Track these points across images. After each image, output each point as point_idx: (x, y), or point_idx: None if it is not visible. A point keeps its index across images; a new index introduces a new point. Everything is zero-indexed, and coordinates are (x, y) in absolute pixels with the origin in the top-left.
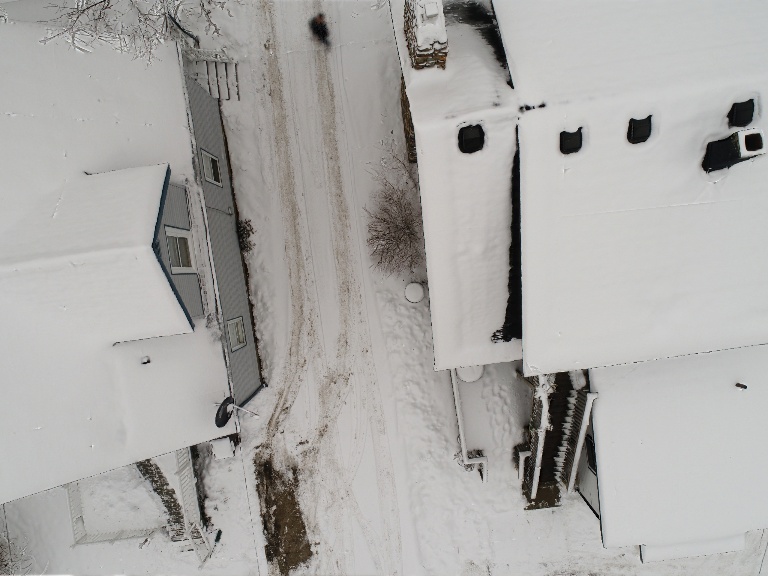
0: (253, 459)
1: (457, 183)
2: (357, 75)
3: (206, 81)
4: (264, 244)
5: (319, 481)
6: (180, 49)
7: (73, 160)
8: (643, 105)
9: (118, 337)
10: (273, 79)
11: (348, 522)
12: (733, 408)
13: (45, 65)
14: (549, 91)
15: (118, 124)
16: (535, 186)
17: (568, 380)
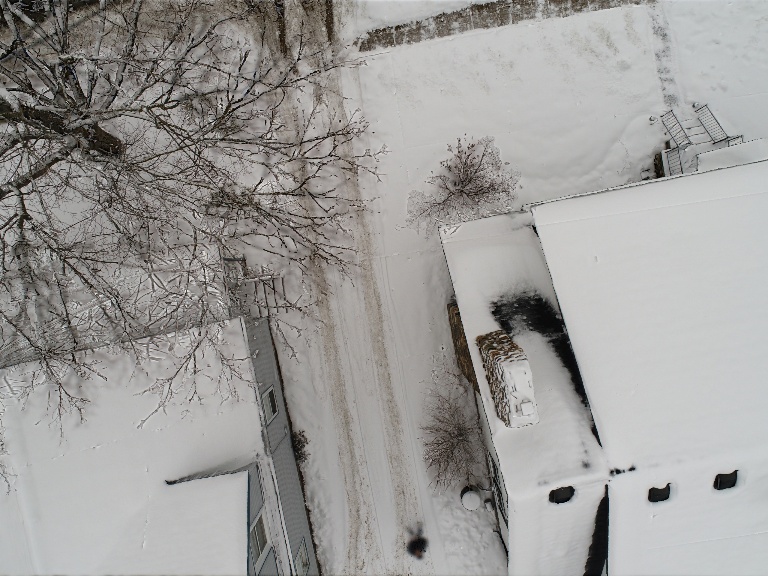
0: None
1: (545, 521)
2: (403, 285)
3: None
4: (318, 452)
5: None
6: (244, 324)
7: (154, 473)
8: (730, 465)
9: None
10: None
11: None
12: None
13: (124, 386)
14: (638, 453)
15: (193, 422)
16: (624, 532)
17: None
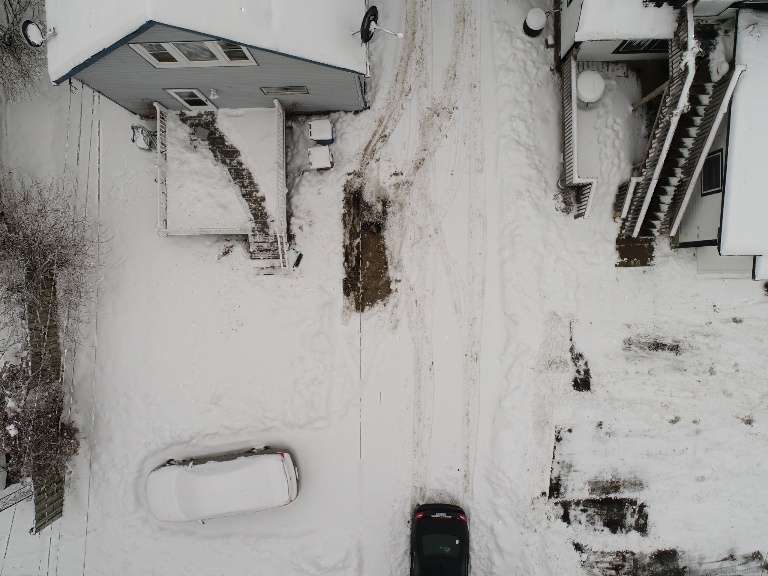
0: (343, 186)
1: None
2: None
3: None
4: None
5: (409, 215)
6: None
7: None
8: None
9: None
10: None
11: (433, 261)
12: None
13: None
14: None
15: None
16: None
17: (707, 71)
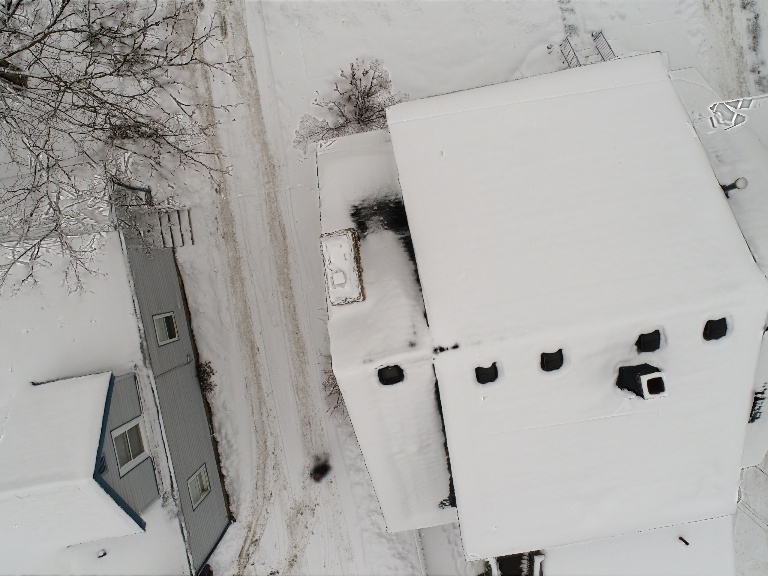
0: None
1: (383, 407)
2: (307, 217)
3: (159, 232)
4: (225, 384)
5: None
6: (123, 237)
7: (19, 373)
8: (552, 342)
9: (71, 543)
10: (226, 222)
11: None
12: (678, 559)
13: None
14: (462, 332)
15: (63, 327)
16: (456, 414)
17: None
